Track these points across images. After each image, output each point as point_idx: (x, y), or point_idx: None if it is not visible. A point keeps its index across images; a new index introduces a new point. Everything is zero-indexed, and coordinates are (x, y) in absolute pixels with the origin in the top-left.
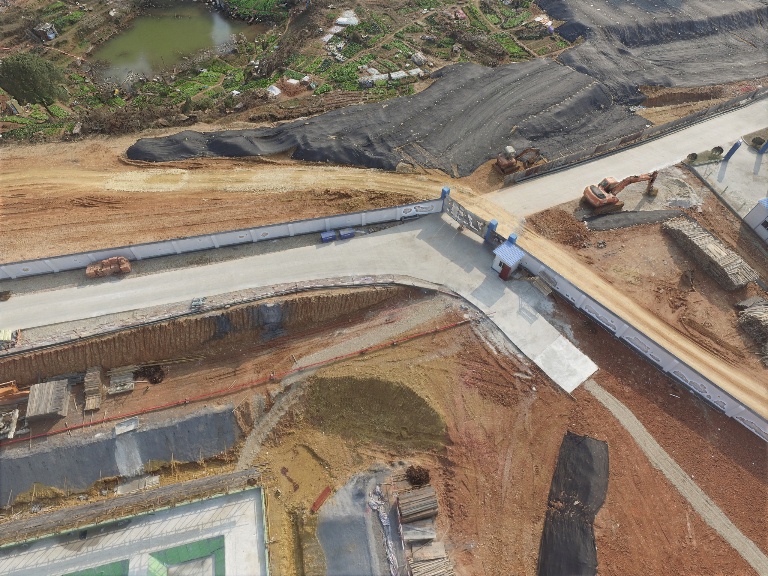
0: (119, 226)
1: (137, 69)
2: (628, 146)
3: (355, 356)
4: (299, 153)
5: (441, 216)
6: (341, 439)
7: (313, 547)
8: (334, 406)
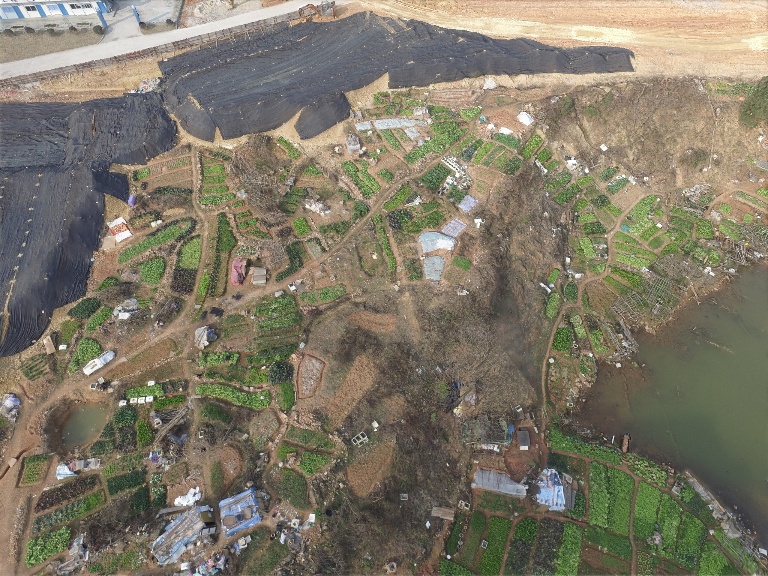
0: (601, 4)
1: (761, 315)
2: None
3: None
4: None
5: None
6: None
7: None
8: None
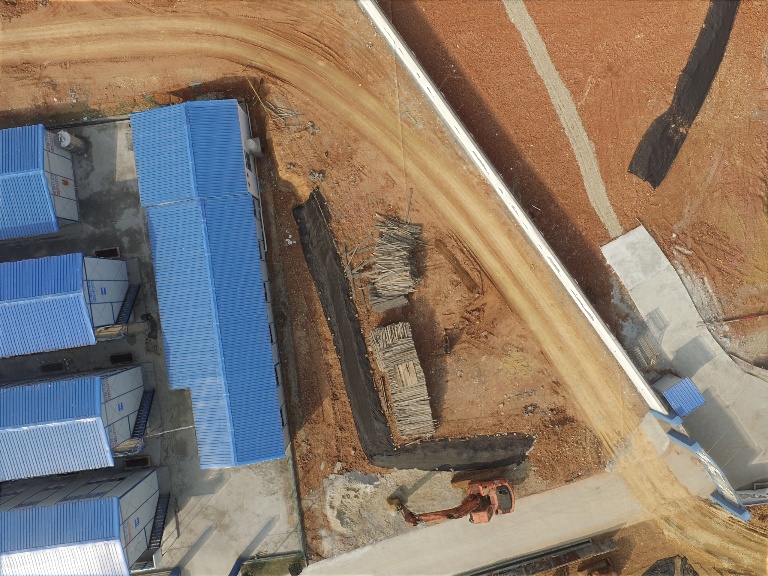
0: None
1: None
2: None
3: None
4: None
5: None
6: None
7: None
8: None
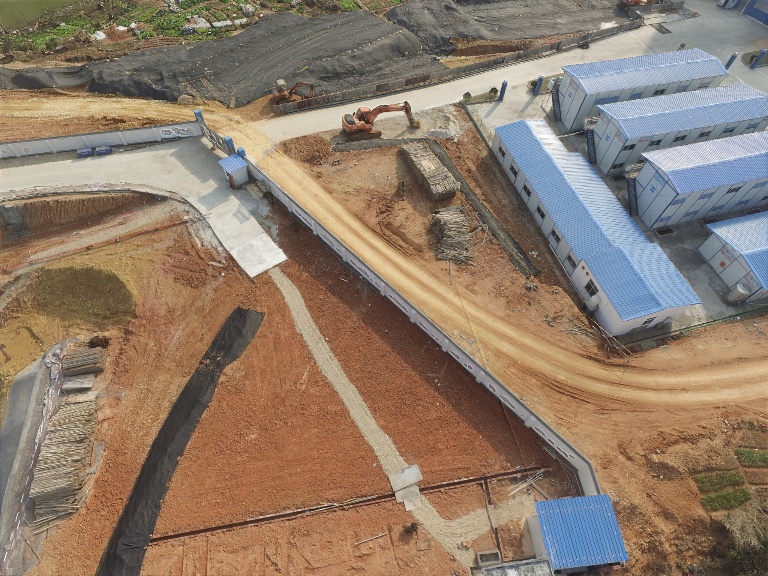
0: None
1: (2, 23)
2: (415, 87)
3: (82, 251)
4: (93, 86)
5: (201, 138)
6: (59, 321)
7: (3, 403)
8: (57, 294)
